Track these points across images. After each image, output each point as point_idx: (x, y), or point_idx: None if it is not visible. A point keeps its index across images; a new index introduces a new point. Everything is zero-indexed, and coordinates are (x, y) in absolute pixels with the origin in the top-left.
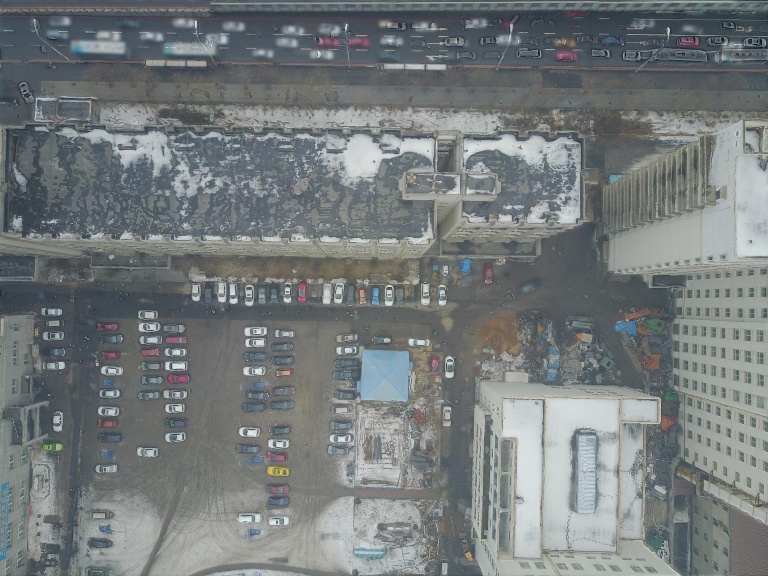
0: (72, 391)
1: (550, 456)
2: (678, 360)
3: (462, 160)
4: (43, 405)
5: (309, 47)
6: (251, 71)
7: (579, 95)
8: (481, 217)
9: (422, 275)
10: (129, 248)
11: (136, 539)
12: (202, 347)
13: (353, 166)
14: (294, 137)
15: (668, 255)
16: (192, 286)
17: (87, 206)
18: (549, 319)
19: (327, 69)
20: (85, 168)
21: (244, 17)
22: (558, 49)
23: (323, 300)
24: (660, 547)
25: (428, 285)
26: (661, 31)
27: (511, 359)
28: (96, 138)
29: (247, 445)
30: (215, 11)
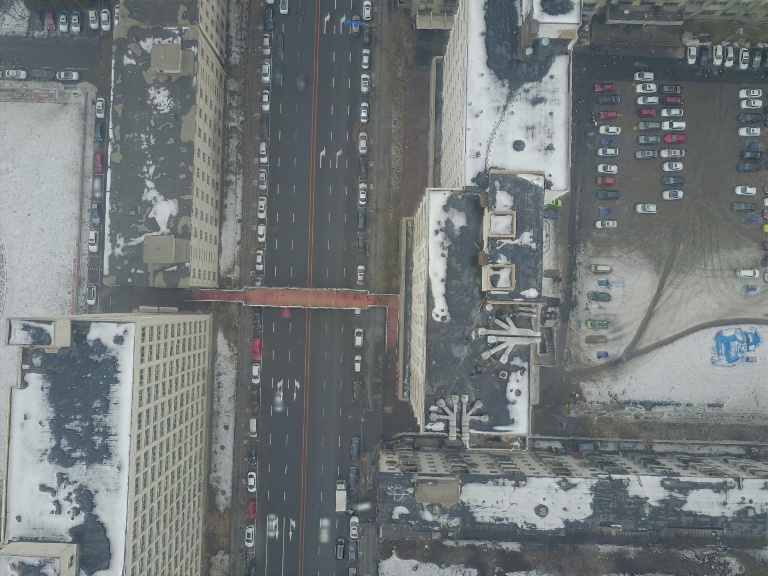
0: None
1: None
2: None
3: None
4: None
5: None
6: None
7: None
8: None
9: None
10: None
11: (634, 294)
12: (696, 109)
13: None
14: None
15: None
16: (689, 48)
17: None
18: None
19: None
20: None
21: None
22: None
23: None
24: None
25: None
26: None
27: None
28: None
29: (745, 203)
30: None
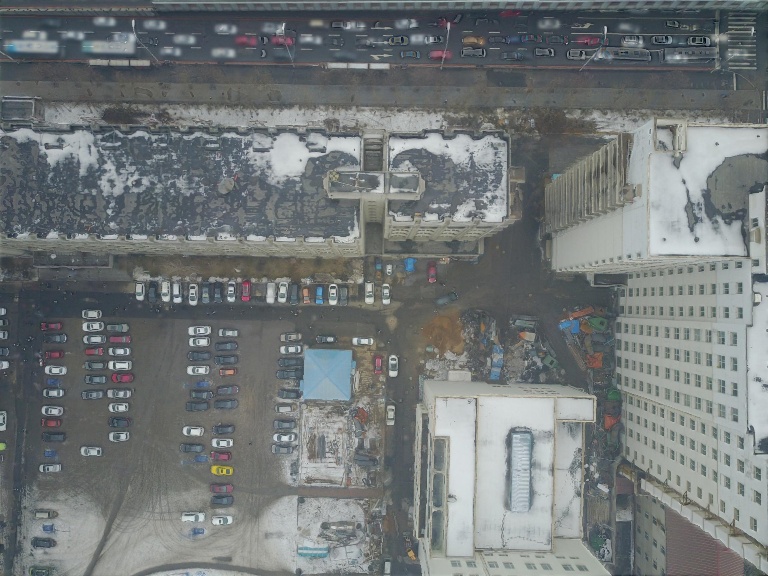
0: (16, 390)
1: (485, 455)
2: (620, 359)
3: (388, 159)
4: None
5: (254, 46)
6: (193, 70)
7: (523, 94)
8: (408, 216)
9: (366, 274)
10: (68, 247)
11: (80, 538)
12: (146, 346)
13: (280, 165)
14: (221, 136)
15: (597, 253)
16: (136, 285)
17: (14, 205)
18: (493, 318)
19: (267, 68)
20: (12, 167)
21: (189, 16)
22: (503, 48)
23: (267, 299)
24: (603, 546)
25: (371, 284)
26: None
27: (455, 358)
28: (23, 137)
29: (191, 444)
30: (158, 10)
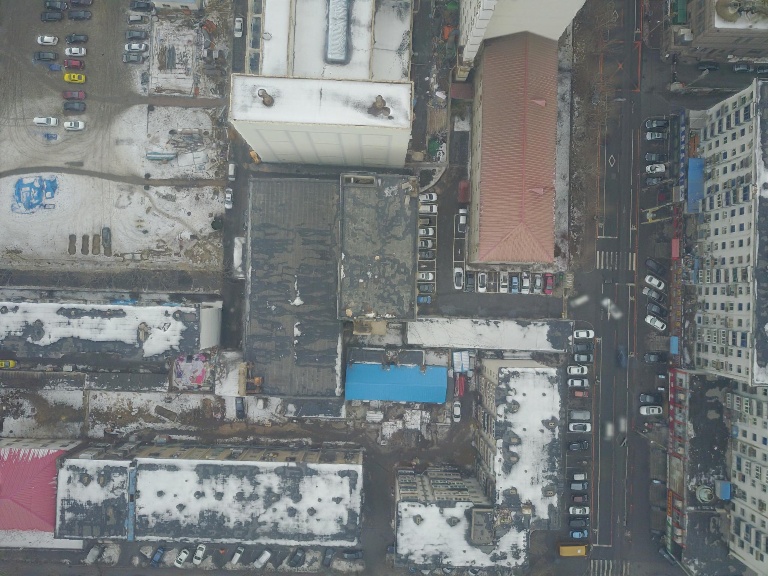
0: None
1: (306, 11)
2: None
3: None
4: None
5: None
6: None
7: None
8: None
9: None
10: None
11: None
12: None
13: None
14: None
15: None
16: None
17: None
18: None
19: None
20: None
21: None
22: None
23: None
24: (438, 149)
25: None
26: None
27: None
28: None
29: (44, 52)
30: None
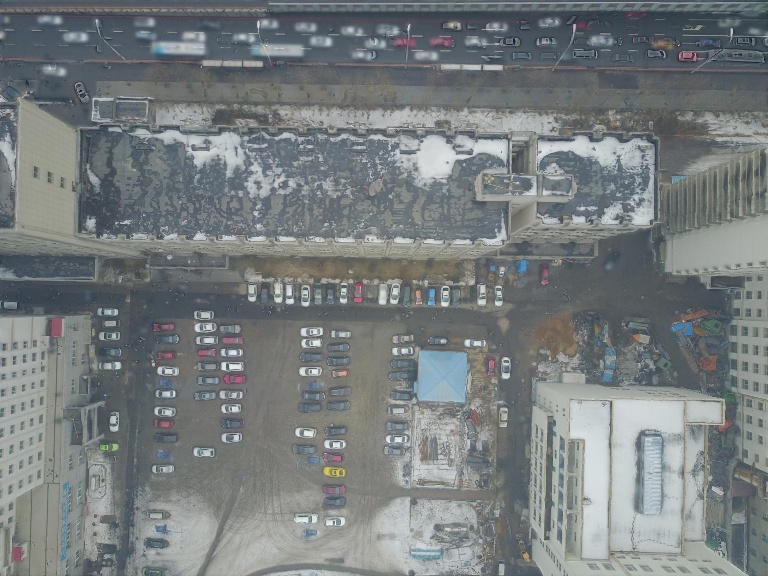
0: (128, 391)
1: (615, 457)
2: (736, 361)
3: (536, 161)
4: (99, 405)
5: (364, 47)
6: (309, 71)
7: (635, 96)
8: (554, 218)
9: (478, 276)
10: (190, 248)
11: (192, 539)
12: (258, 347)
13: (426, 167)
14: (367, 138)
15: (739, 256)
16: (248, 286)
17: (160, 207)
18: (606, 320)
19: (387, 69)
20: (158, 169)
21: (299, 17)
22: (614, 50)
23: (379, 301)
24: (717, 548)
25: (485, 286)
26: (717, 32)
27: (567, 360)
28: (169, 139)
29: (303, 445)
30: (272, 11)
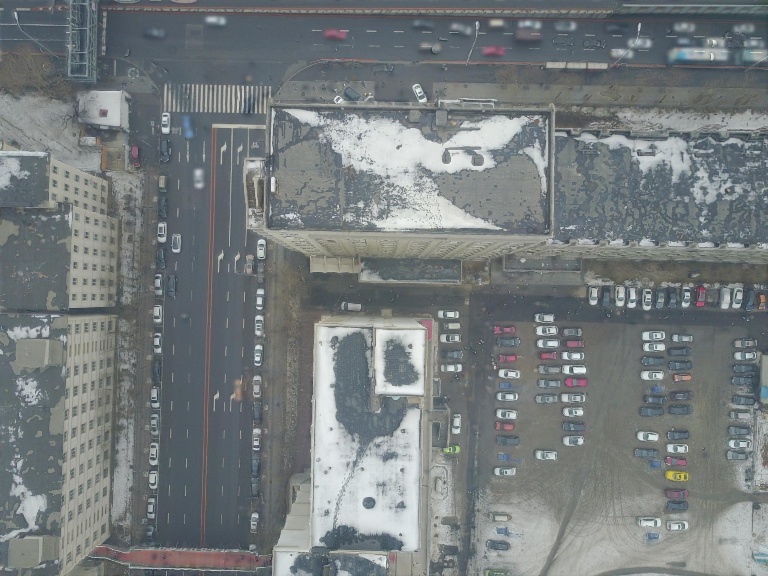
0: (468, 393)
1: None
2: None
3: None
4: None
5: (702, 49)
6: (664, 74)
7: None
8: None
9: None
10: None
11: (533, 542)
12: (598, 351)
13: None
14: None
15: None
16: (591, 290)
17: (605, 212)
18: None
19: None
20: (603, 174)
21: (637, 19)
22: None
23: (722, 305)
24: None
25: None
26: None
27: None
28: (615, 143)
29: (647, 449)
30: (617, 13)
